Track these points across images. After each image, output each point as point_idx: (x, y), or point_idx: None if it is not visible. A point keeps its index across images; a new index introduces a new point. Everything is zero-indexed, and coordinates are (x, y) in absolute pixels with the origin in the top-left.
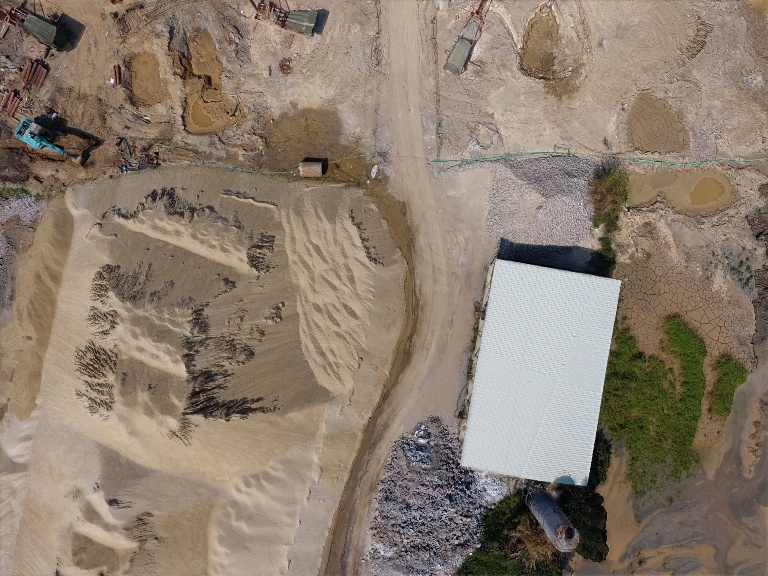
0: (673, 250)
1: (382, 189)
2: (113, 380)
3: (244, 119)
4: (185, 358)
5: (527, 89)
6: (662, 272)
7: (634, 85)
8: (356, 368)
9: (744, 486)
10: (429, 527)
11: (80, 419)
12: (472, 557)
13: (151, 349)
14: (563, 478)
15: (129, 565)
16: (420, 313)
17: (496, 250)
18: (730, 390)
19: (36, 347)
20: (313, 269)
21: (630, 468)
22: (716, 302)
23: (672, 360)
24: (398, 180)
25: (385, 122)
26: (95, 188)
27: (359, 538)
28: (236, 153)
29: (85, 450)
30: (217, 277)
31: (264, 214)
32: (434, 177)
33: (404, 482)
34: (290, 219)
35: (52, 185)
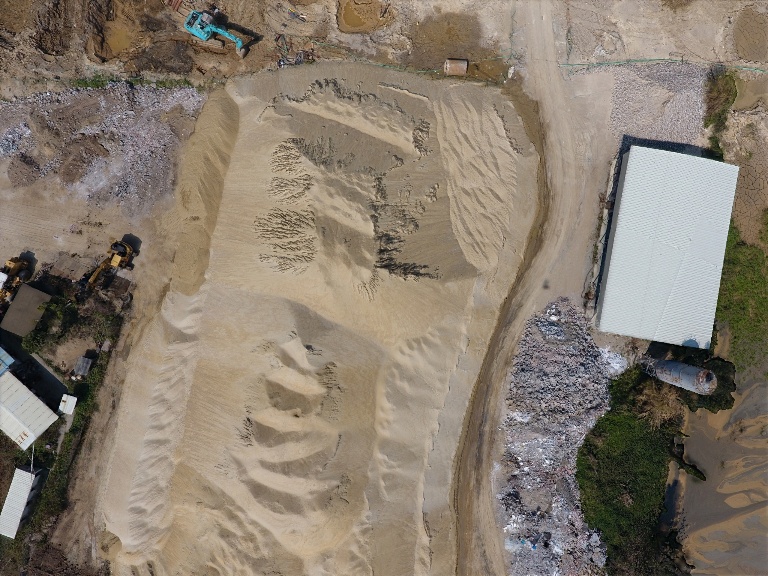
0: None
1: (517, 89)
2: (314, 233)
3: (393, 20)
4: (373, 218)
5: (646, 2)
6: (762, 170)
7: (739, 1)
8: (501, 247)
9: None
10: (565, 392)
11: (265, 280)
12: (604, 418)
13: (344, 208)
14: (690, 341)
15: (320, 408)
16: (551, 203)
17: (618, 147)
18: None
19: (205, 225)
20: (461, 156)
21: (733, 346)
22: None
23: None
24: (532, 81)
25: (520, 27)
26: (256, 79)
27: (496, 408)
28: (385, 51)
29: (273, 307)
30: (388, 153)
31: (419, 104)
32: (564, 79)
33: (541, 353)
34: (441, 110)
35: (214, 77)
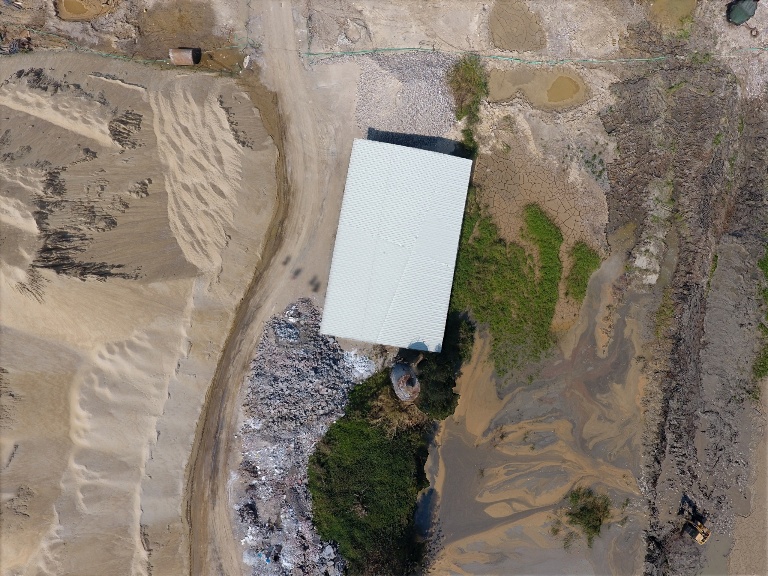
0: (531, 143)
1: (254, 79)
2: None
3: (117, 7)
4: (36, 214)
5: None
6: (521, 164)
7: None
8: (224, 245)
9: (599, 365)
10: (295, 398)
11: None
12: (336, 425)
13: (0, 204)
14: (417, 344)
15: None
16: (291, 199)
17: None
18: (584, 274)
19: None
20: (182, 150)
21: (493, 348)
22: (572, 193)
23: (531, 247)
24: (270, 71)
25: (257, 15)
26: None
27: (232, 415)
28: (109, 40)
29: None
30: (77, 146)
31: (132, 95)
32: (305, 69)
33: (273, 357)
34: (158, 101)
35: None
